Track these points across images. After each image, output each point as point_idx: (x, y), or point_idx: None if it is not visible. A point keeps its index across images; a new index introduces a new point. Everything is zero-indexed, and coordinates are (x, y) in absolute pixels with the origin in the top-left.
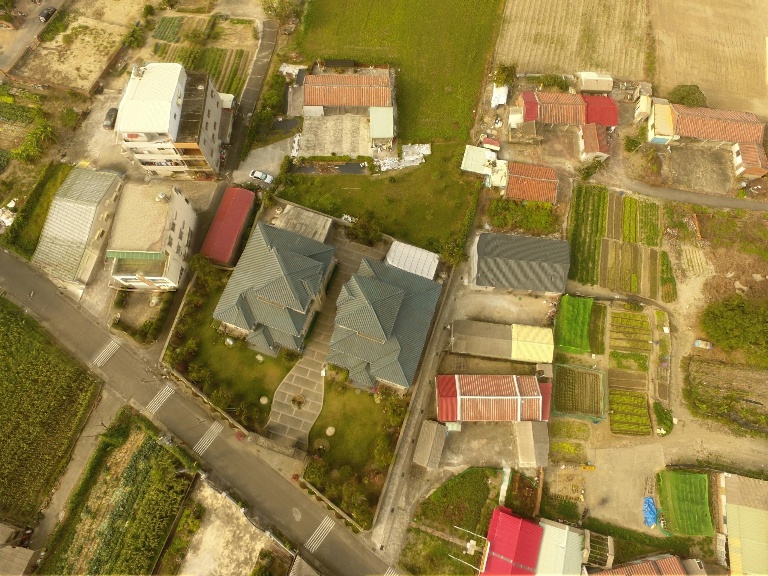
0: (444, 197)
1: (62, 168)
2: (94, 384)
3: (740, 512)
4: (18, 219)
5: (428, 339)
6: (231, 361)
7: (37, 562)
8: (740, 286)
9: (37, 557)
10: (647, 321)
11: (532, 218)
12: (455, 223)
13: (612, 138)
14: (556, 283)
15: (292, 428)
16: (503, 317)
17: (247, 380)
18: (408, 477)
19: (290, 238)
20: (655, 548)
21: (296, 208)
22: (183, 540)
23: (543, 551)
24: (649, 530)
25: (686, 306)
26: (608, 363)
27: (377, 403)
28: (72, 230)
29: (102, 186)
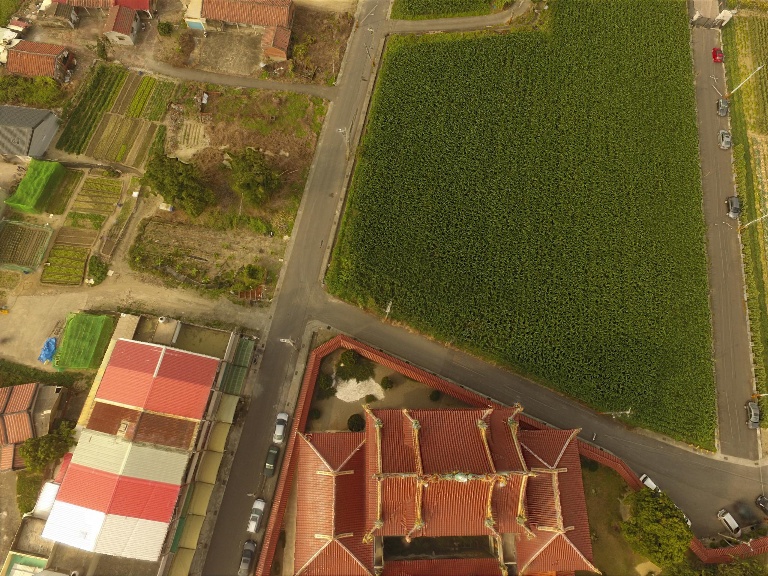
0: None
1: None
2: None
3: None
4: None
5: None
6: None
7: None
8: (229, 157)
9: None
10: (120, 186)
11: (37, 93)
12: None
13: (152, 24)
14: (18, 146)
15: None
16: None
17: None
18: None
19: None
20: (34, 379)
21: None
22: None
23: None
24: (42, 366)
25: None
26: (63, 222)
27: None
28: None
29: None
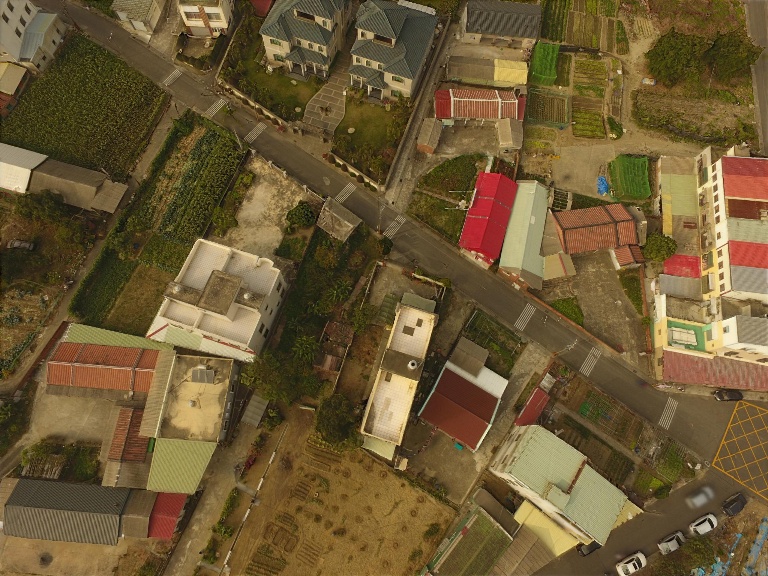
0: None
1: None
2: (164, 94)
3: (671, 178)
4: None
5: (428, 69)
6: (271, 83)
7: (129, 202)
8: None
9: (128, 199)
10: (604, 66)
11: None
12: None
13: None
14: (530, 31)
15: None
16: None
17: (284, 96)
18: (413, 160)
19: None
20: None
21: None
22: (239, 193)
23: (518, 199)
24: (601, 197)
25: (636, 56)
26: (572, 92)
27: (388, 111)
28: None
29: None
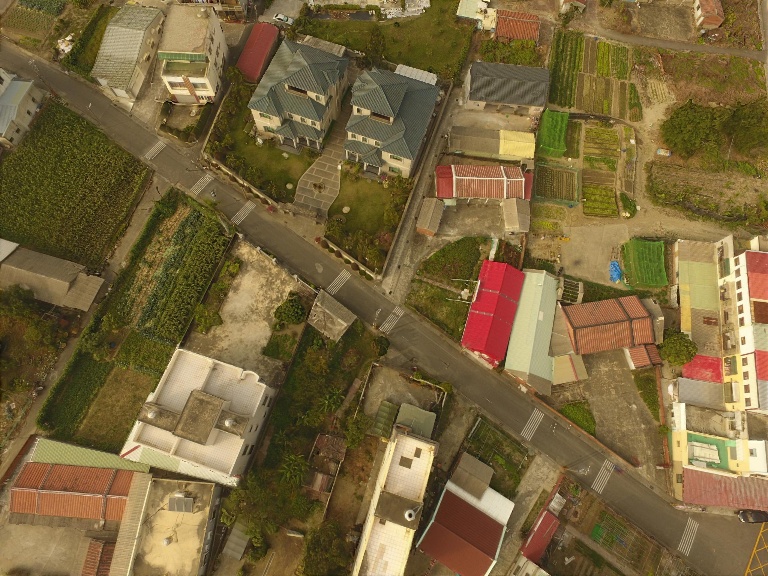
0: (442, 39)
1: (112, 9)
2: (146, 170)
3: (690, 266)
4: (77, 45)
5: (428, 141)
6: (261, 157)
7: (105, 294)
8: None
9: (105, 291)
10: (616, 135)
11: (518, 56)
12: (451, 59)
13: None
14: (538, 98)
15: (314, 207)
16: (492, 129)
17: (275, 171)
18: (412, 243)
19: (311, 50)
20: (619, 295)
21: (315, 38)
22: (225, 283)
23: (524, 290)
24: (614, 285)
25: (650, 124)
26: (582, 165)
27: (385, 188)
28: (124, 50)
29: (148, 17)
